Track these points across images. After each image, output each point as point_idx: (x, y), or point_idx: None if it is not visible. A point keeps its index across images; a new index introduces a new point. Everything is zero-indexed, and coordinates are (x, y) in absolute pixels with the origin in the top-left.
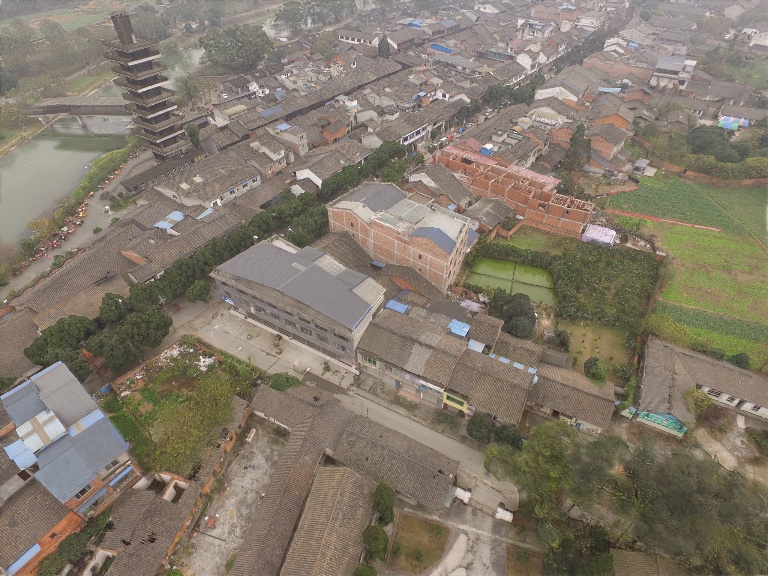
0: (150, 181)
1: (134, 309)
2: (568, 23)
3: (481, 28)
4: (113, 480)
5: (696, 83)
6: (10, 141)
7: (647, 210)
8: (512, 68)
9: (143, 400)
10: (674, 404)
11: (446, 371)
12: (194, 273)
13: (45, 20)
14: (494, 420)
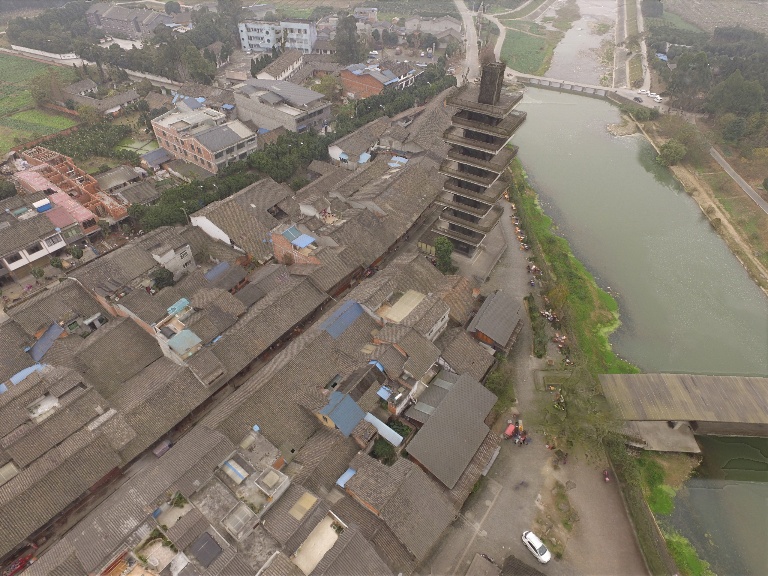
0: None
1: None
2: None
3: None
4: None
5: None
6: None
7: None
8: None
9: None
10: None
11: None
12: None
13: None
14: None
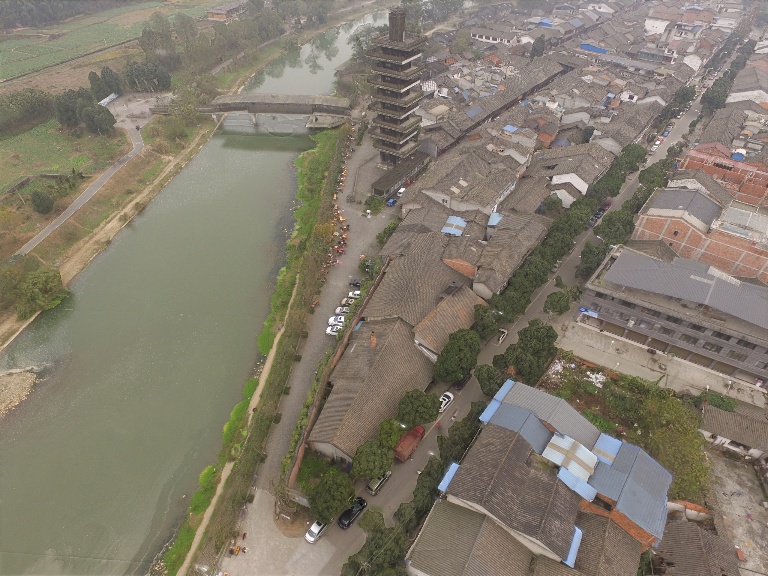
0: (396, 184)
1: (501, 321)
2: (701, 24)
3: (609, 28)
4: None
5: None
6: (194, 139)
7: None
8: (685, 70)
9: None
10: None
11: None
12: None
13: (179, 14)
14: None
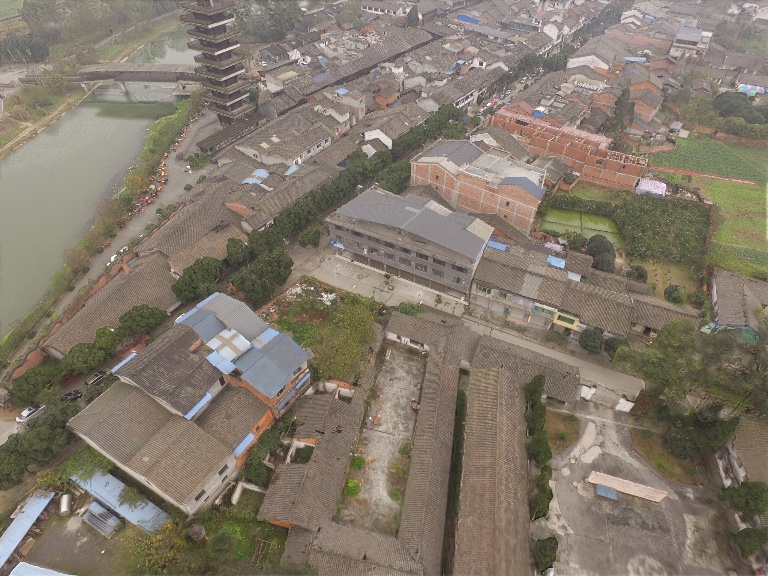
0: (223, 142)
1: (254, 253)
2: None
3: None
4: (298, 384)
5: (713, 53)
6: (58, 107)
7: (687, 167)
8: (541, 38)
9: (283, 329)
10: (749, 318)
11: (558, 295)
12: (300, 222)
13: None
14: (602, 334)
